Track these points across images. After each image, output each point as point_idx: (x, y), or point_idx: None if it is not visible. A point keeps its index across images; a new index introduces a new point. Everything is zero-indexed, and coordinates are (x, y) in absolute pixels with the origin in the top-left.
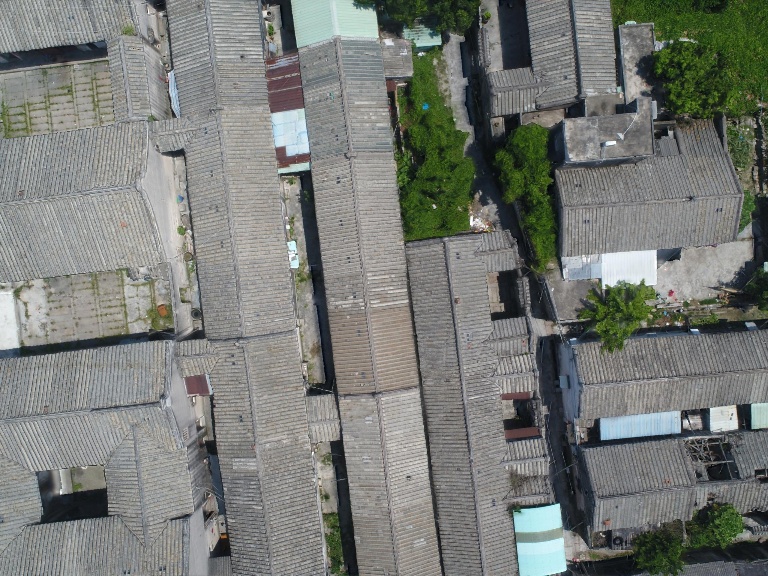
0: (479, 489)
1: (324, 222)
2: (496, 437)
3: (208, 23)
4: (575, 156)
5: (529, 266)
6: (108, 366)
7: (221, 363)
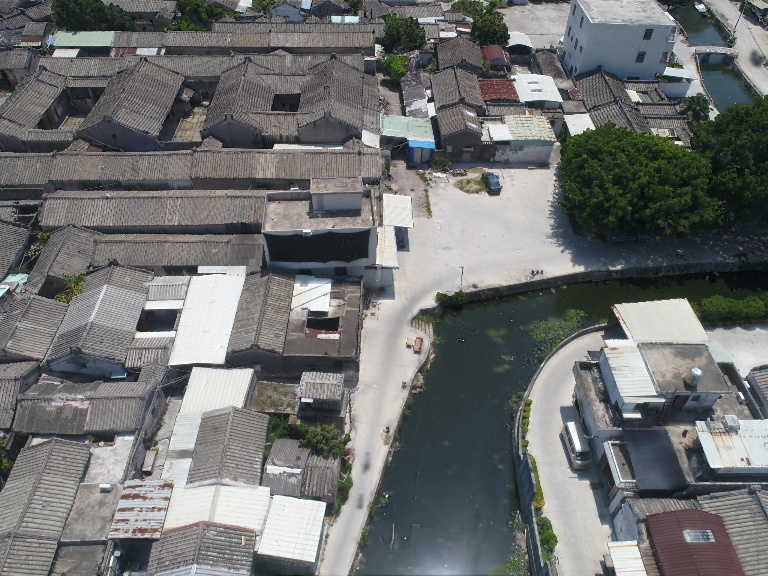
0: None
1: (191, 44)
2: None
3: None
4: None
5: None
6: None
7: None
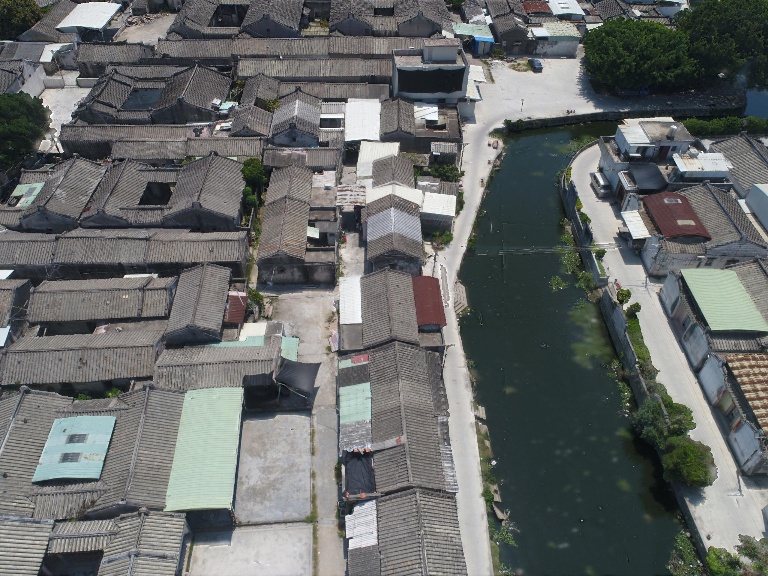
0: None
1: None
2: None
3: None
4: None
5: None
6: None
7: None
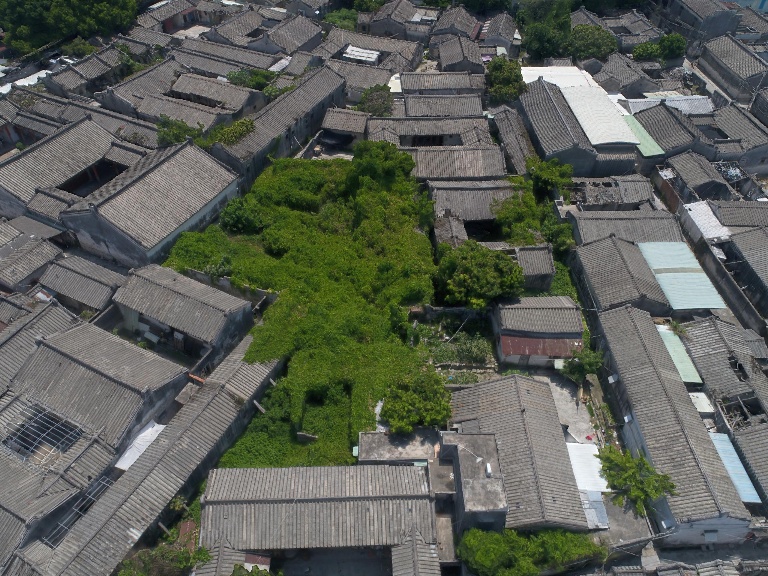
0: None
1: None
2: None
3: None
4: (501, 502)
5: (591, 568)
6: None
7: None
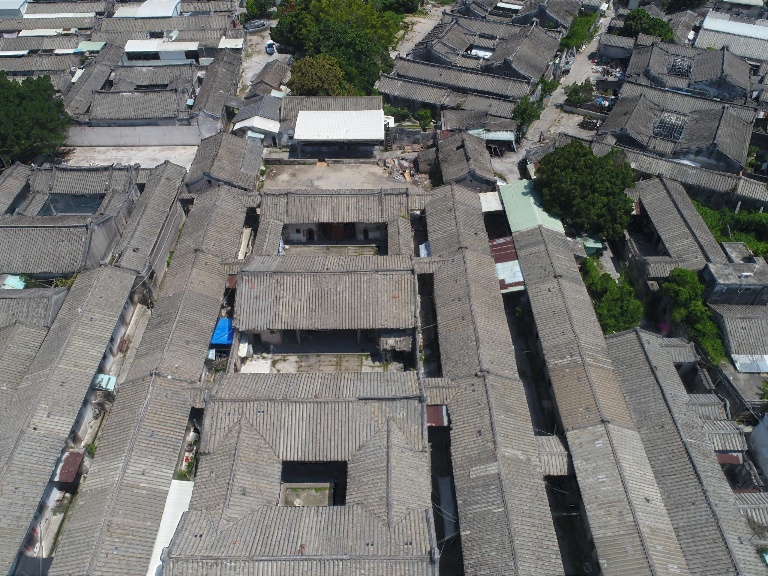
0: (721, 521)
1: (540, 314)
2: (721, 481)
3: (456, 216)
4: (722, 281)
5: None
6: (368, 380)
7: (461, 393)
